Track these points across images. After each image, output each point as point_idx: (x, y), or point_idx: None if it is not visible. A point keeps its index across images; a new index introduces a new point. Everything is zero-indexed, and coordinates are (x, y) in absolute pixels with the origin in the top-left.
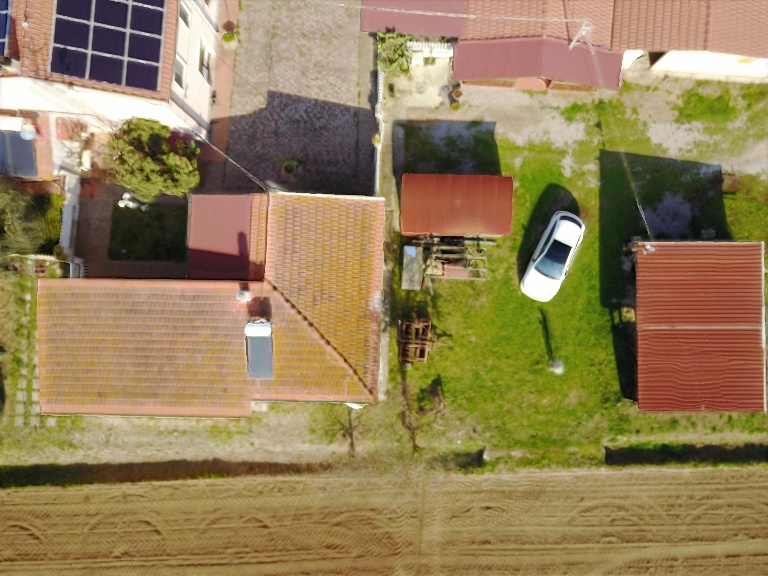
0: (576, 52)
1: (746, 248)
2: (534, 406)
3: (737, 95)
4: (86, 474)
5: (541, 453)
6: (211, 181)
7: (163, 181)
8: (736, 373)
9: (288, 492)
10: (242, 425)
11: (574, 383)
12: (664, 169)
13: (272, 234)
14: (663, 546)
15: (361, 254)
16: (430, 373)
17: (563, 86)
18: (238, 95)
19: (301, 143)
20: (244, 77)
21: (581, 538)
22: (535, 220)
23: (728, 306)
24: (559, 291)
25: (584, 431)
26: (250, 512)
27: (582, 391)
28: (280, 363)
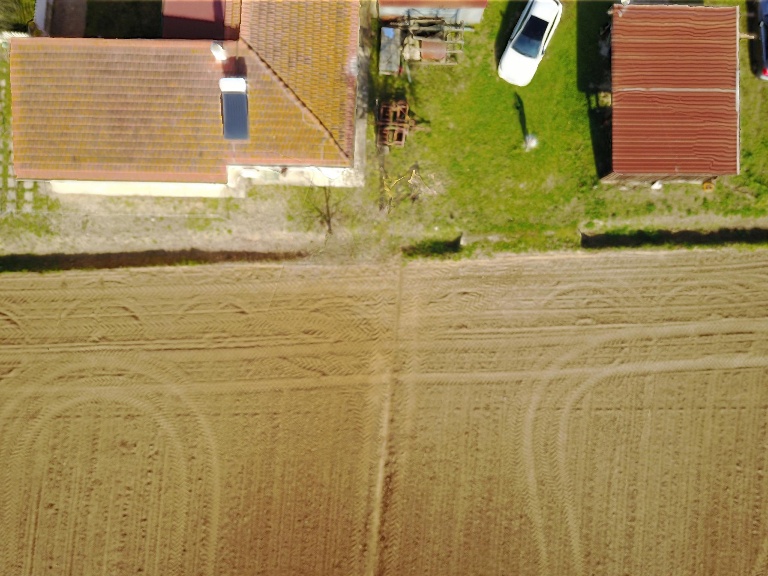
0: None
1: (721, 13)
2: (511, 191)
3: None
4: (63, 262)
5: (518, 237)
6: None
7: None
8: (709, 134)
9: (266, 279)
10: (219, 212)
11: (551, 168)
12: None
13: None
14: (637, 327)
15: (337, 18)
16: (408, 160)
17: None
18: None
19: None
20: None
21: (557, 320)
22: (513, 6)
23: (702, 69)
24: (536, 76)
25: (560, 215)
26: (228, 298)
27: (559, 176)
28: (255, 126)
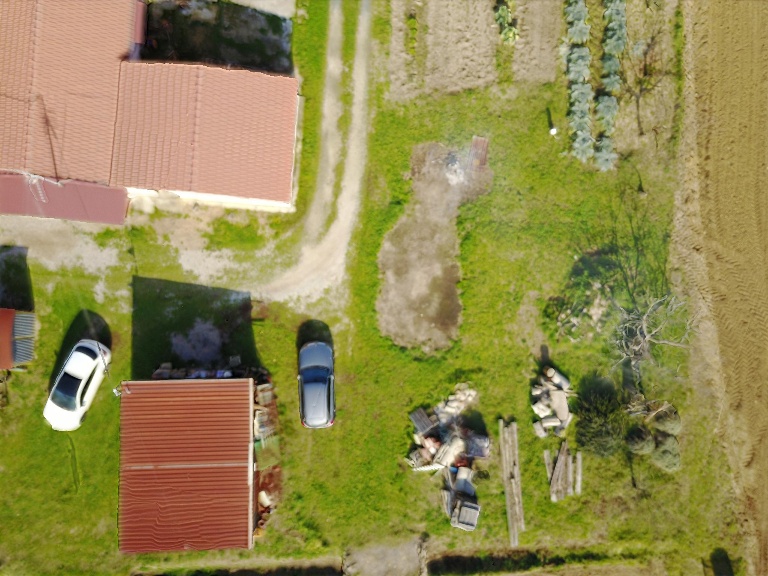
0: (69, 189)
1: (237, 384)
2: (61, 537)
3: (265, 223)
4: None
5: None
6: None
7: None
8: (217, 511)
9: None
10: None
11: (102, 512)
12: (196, 295)
13: None
14: None
15: None
16: None
17: None
18: None
19: None
20: None
21: None
22: (67, 346)
23: (213, 444)
24: (89, 419)
25: (111, 561)
26: None
27: (110, 520)
28: None
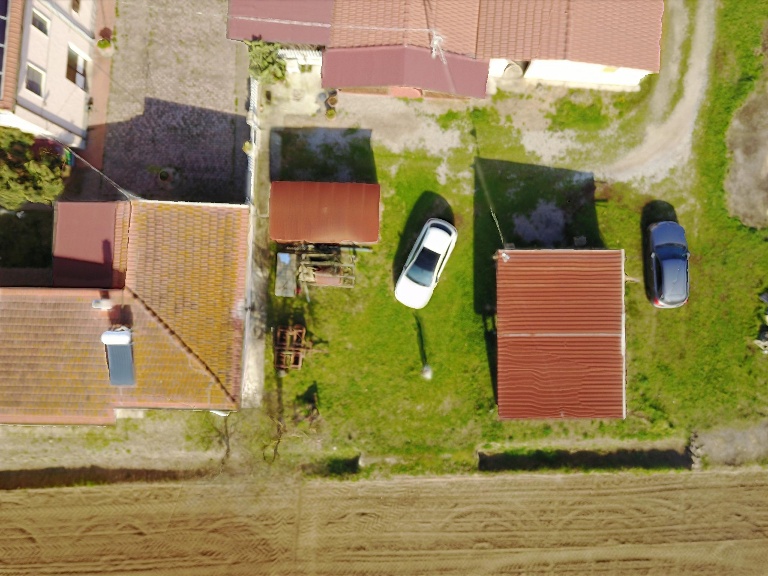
0: (440, 60)
1: (607, 256)
2: (409, 412)
3: (609, 103)
4: None
5: (415, 459)
6: (88, 188)
7: (24, 189)
8: (595, 380)
9: (164, 499)
10: (118, 432)
11: (448, 389)
12: (538, 176)
13: (133, 242)
14: (535, 551)
15: (224, 262)
16: (306, 380)
17: (435, 94)
18: (115, 102)
19: (178, 150)
20: (121, 84)
21: (454, 544)
22: (410, 227)
23: (588, 313)
24: (434, 298)
25: (458, 437)
26: (126, 519)
27: (456, 397)
28: (142, 371)
